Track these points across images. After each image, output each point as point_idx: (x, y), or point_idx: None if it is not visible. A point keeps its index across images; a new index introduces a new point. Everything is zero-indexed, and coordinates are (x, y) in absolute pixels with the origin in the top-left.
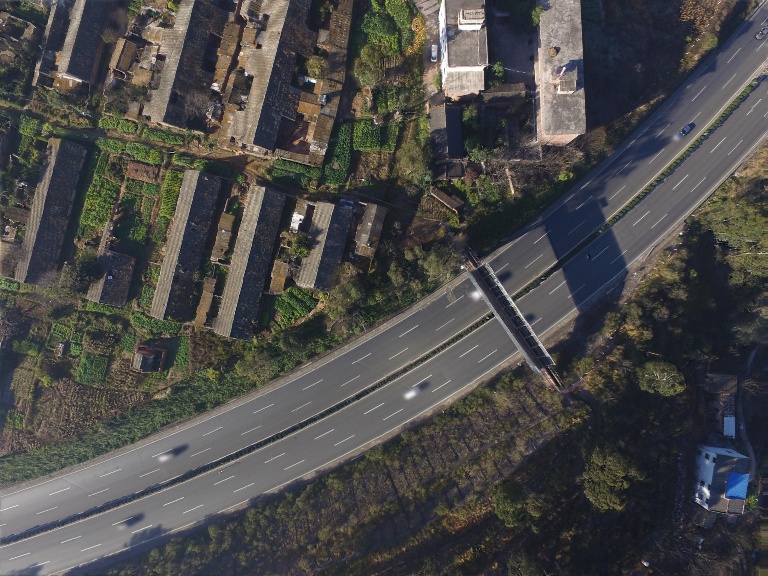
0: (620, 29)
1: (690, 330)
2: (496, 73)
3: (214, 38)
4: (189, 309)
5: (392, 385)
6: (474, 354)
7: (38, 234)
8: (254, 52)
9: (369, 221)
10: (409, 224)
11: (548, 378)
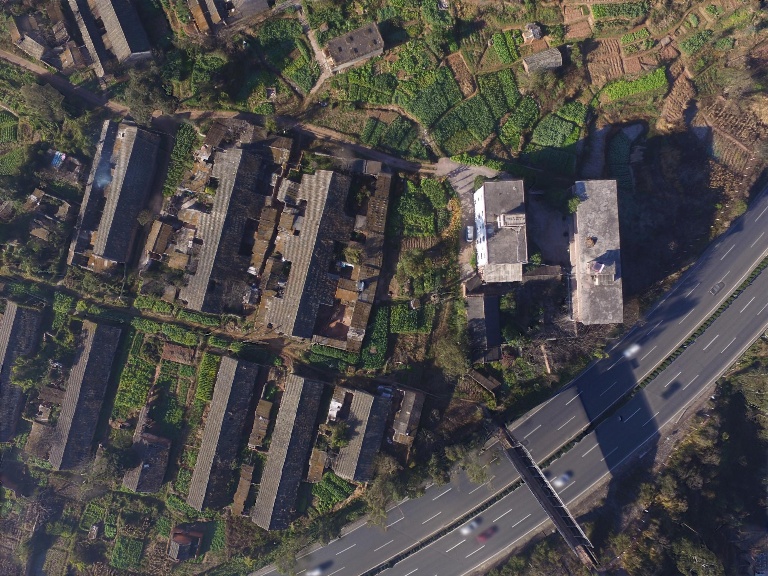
0: (651, 196)
1: (722, 490)
2: (534, 262)
3: (251, 221)
4: (226, 496)
5: (426, 550)
6: (508, 518)
7: (73, 420)
8: (291, 238)
9: (408, 410)
10: (446, 406)
11: (585, 555)
